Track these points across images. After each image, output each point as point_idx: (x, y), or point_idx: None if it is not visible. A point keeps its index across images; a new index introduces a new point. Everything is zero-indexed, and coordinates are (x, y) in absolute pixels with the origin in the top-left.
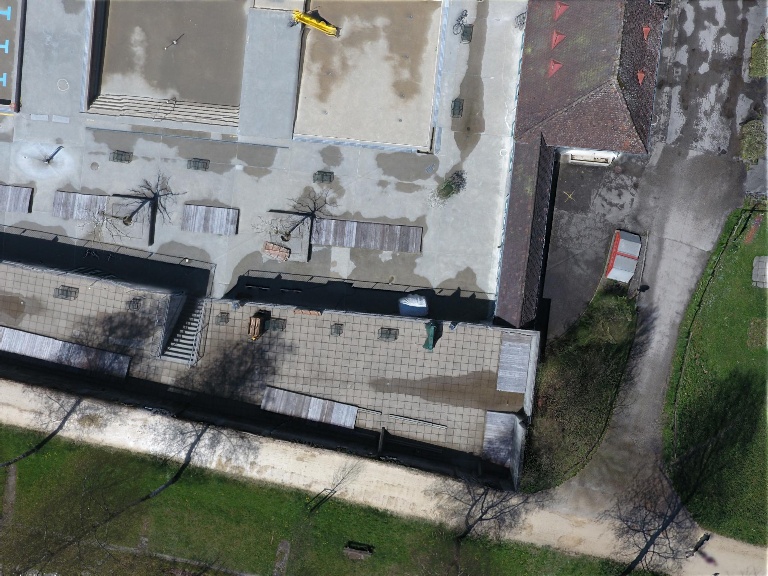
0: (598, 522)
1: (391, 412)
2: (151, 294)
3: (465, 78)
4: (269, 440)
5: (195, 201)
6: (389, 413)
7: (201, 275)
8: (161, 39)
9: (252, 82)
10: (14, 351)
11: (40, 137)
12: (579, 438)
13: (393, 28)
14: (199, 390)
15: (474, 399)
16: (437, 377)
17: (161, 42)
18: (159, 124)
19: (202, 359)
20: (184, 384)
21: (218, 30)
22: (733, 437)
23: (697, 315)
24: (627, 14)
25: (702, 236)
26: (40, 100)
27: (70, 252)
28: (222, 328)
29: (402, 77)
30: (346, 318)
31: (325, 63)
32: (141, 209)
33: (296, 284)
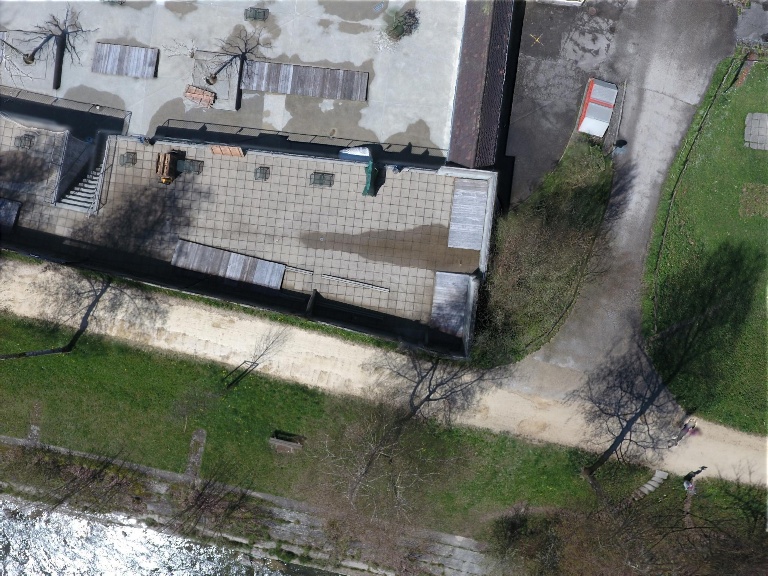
0: (565, 404)
1: (324, 272)
2: (46, 130)
3: None
4: (180, 302)
5: (109, 39)
6: (322, 273)
7: (114, 124)
8: None
9: None
10: None
11: None
12: (544, 307)
13: None
14: (100, 243)
15: (422, 258)
16: (379, 231)
17: None
18: None
19: (104, 207)
20: (82, 236)
21: None
22: (723, 317)
23: None
24: None
25: (687, 88)
26: None
27: None
28: (128, 170)
29: None
30: (273, 160)
31: None
32: (45, 45)
33: (223, 136)
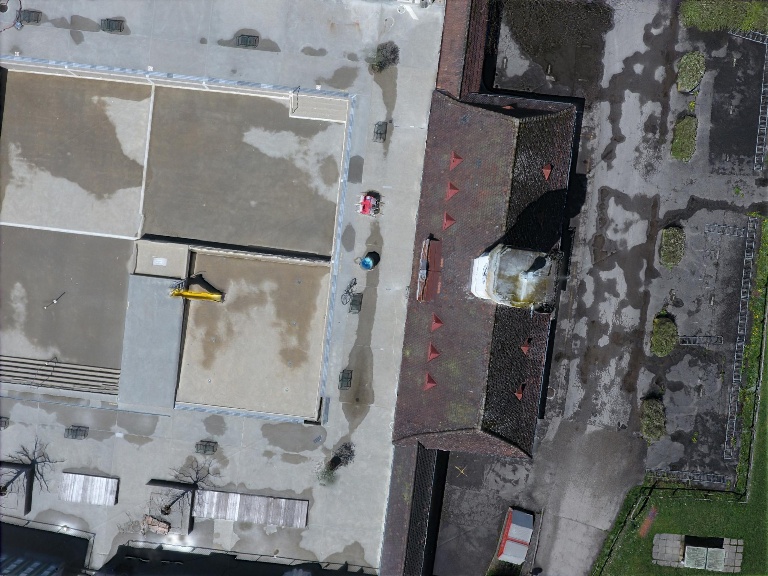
0: None
1: None
2: None
3: (354, 348)
4: None
5: (73, 469)
6: None
7: (79, 544)
8: (41, 298)
9: (132, 350)
10: None
11: None
12: None
13: (280, 293)
14: None
15: None
16: None
17: (41, 301)
18: (36, 391)
19: None
20: None
21: (100, 289)
22: None
23: None
24: (498, 347)
25: (599, 514)
26: None
27: None
28: None
29: (289, 345)
30: None
31: (209, 329)
32: (16, 480)
33: (177, 555)
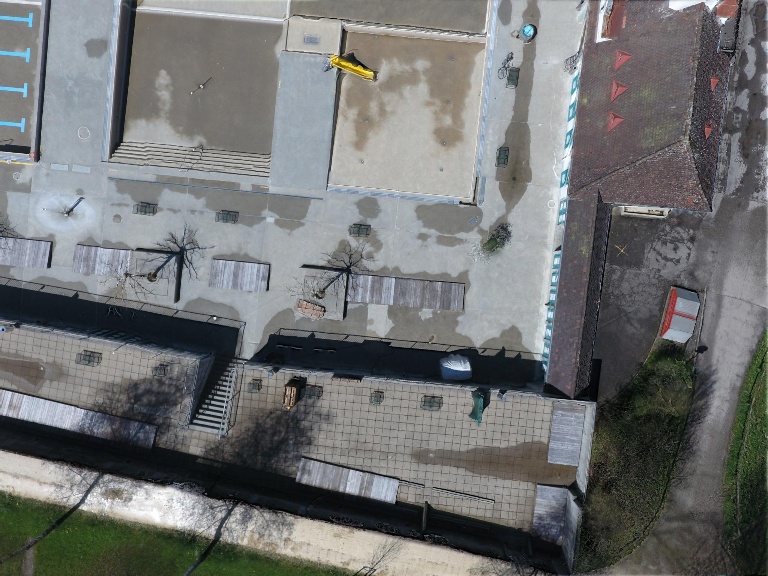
0: None
1: (434, 485)
2: (179, 359)
3: (511, 125)
4: None
5: (223, 255)
6: (432, 486)
7: (230, 334)
8: (187, 83)
9: (284, 130)
10: (33, 420)
11: (59, 188)
12: (635, 512)
13: (434, 72)
14: (230, 461)
15: (523, 471)
16: (484, 448)
17: (187, 86)
18: (185, 174)
19: (233, 428)
20: (214, 455)
21: (247, 73)
22: None
23: (758, 377)
24: None
25: (763, 293)
26: (60, 150)
27: (91, 310)
28: (254, 396)
29: (443, 124)
30: (387, 385)
31: (361, 109)
32: (166, 265)
33: (330, 343)
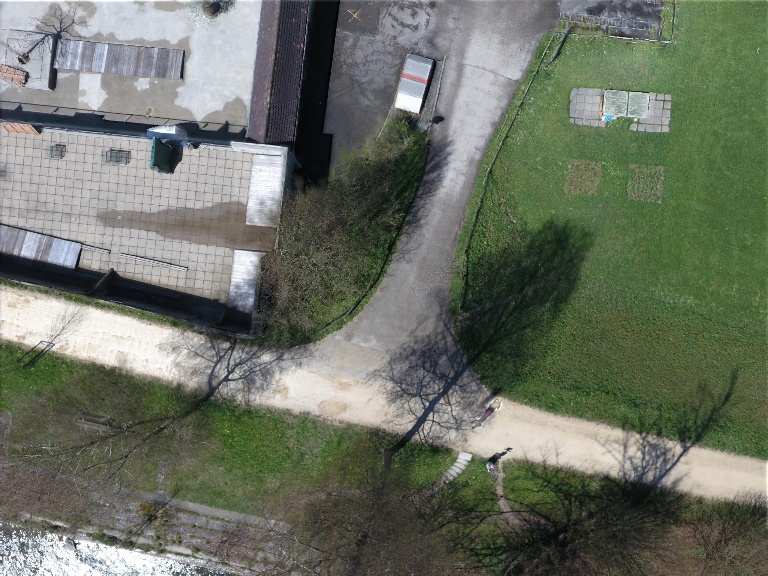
0: (366, 384)
1: (122, 251)
2: None
3: None
4: None
5: None
6: (120, 252)
7: None
8: None
9: None
10: None
11: None
12: (347, 285)
13: None
14: None
15: (220, 236)
16: (176, 209)
17: None
18: None
19: None
20: None
21: None
22: (544, 296)
23: (501, 153)
24: None
25: (508, 62)
26: None
27: None
28: None
29: None
30: (69, 138)
31: None
32: None
33: (38, 116)
